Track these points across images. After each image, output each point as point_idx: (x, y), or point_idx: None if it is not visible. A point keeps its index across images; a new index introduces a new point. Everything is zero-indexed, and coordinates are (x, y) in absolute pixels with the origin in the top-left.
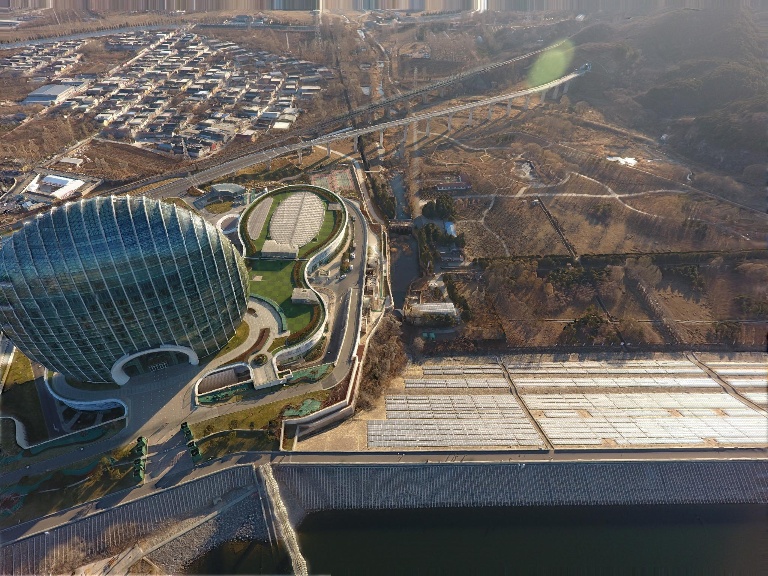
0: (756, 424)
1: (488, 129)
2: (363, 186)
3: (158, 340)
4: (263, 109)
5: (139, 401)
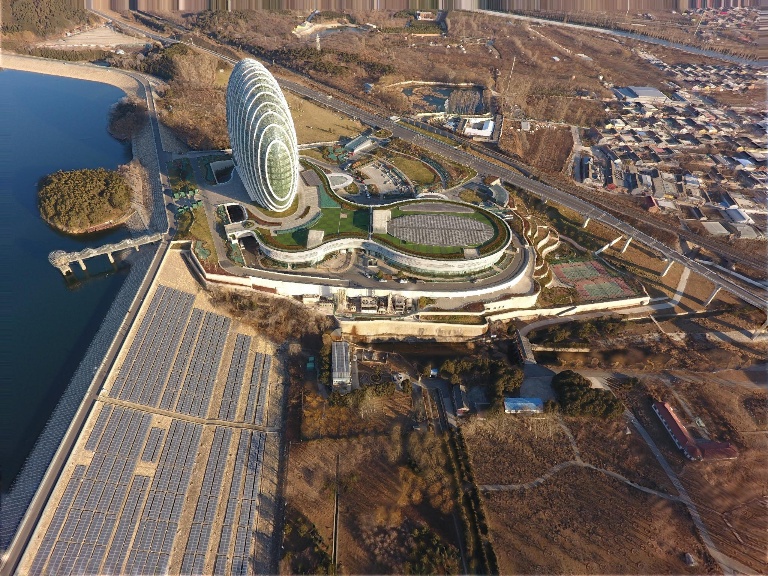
0: None
1: None
2: (606, 313)
3: None
4: (752, 209)
5: (228, 186)
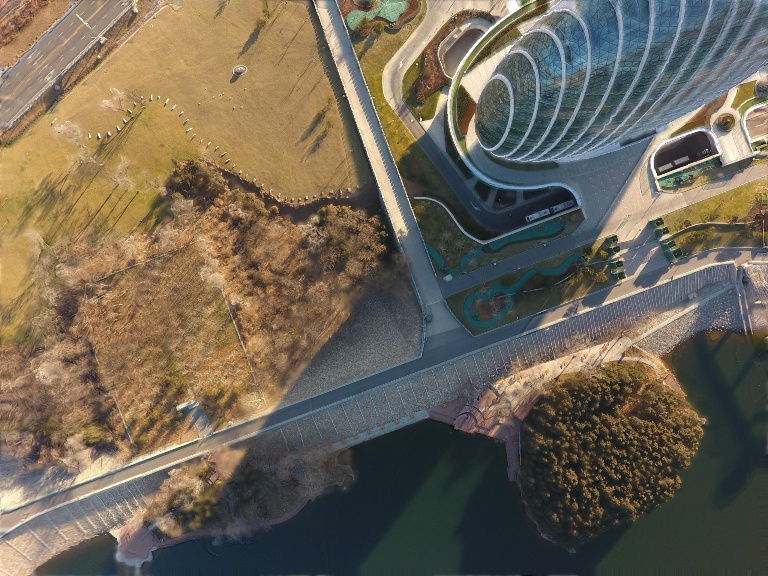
0: None
1: None
2: None
3: (662, 125)
4: None
5: (588, 186)
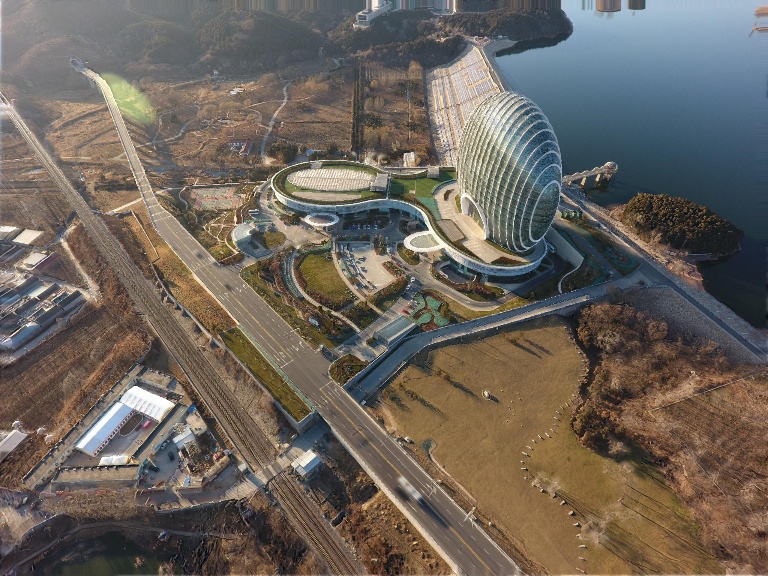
0: None
1: (143, 126)
2: None
3: None
4: None
5: None
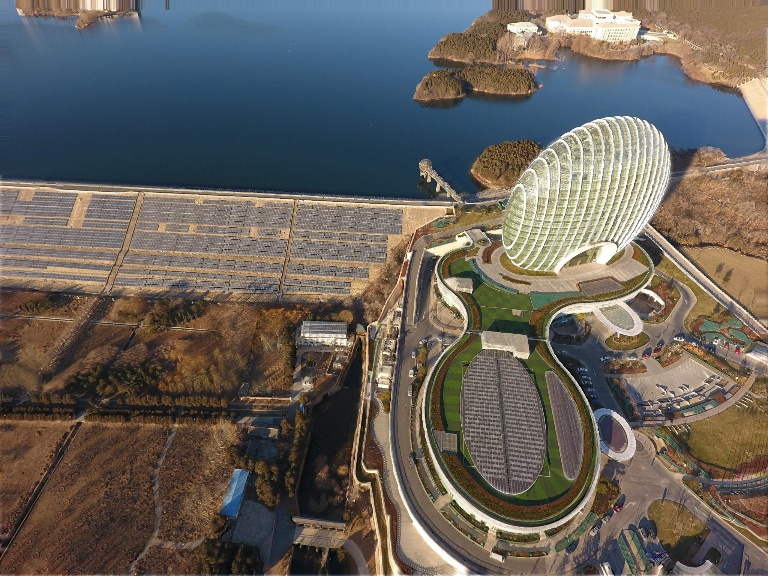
0: (152, 214)
1: None
2: None
3: None
4: None
5: None
